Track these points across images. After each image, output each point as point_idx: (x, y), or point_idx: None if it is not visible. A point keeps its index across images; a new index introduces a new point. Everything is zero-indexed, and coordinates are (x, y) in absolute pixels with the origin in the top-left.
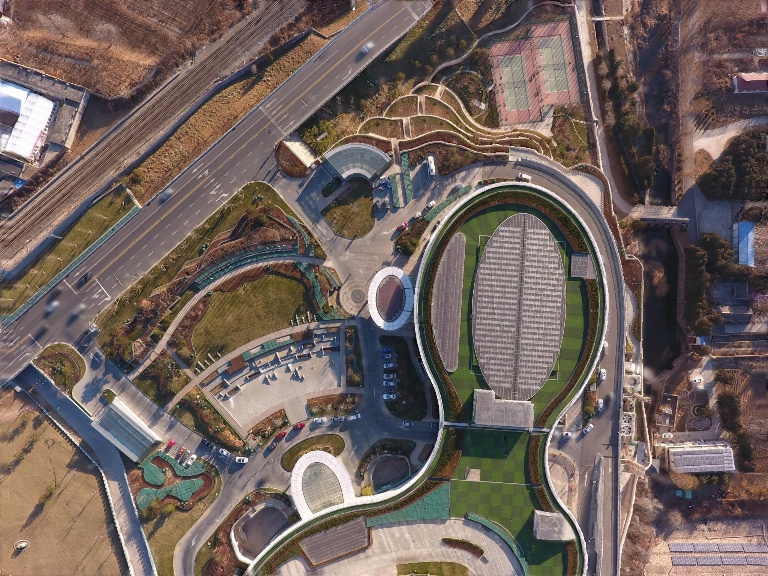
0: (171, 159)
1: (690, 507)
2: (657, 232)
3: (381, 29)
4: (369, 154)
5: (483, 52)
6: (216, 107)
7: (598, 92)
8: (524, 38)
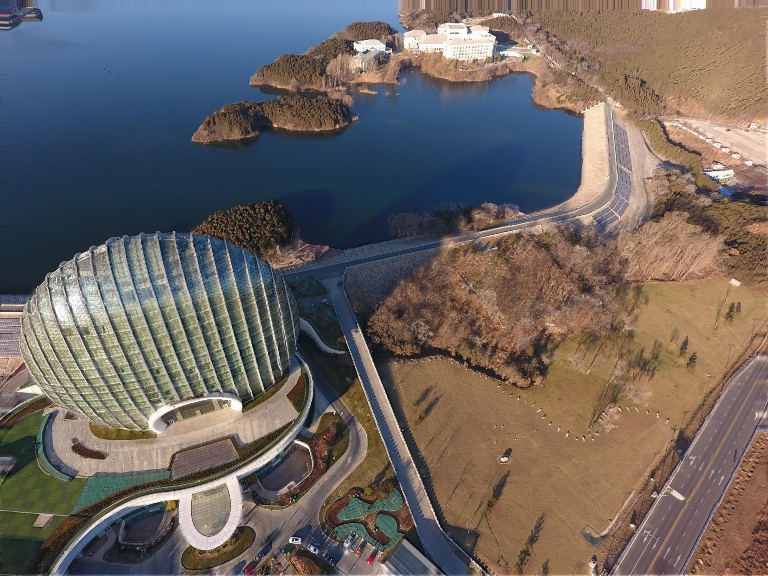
0: None
1: None
2: None
3: None
4: None
5: None
6: None
7: None
8: None
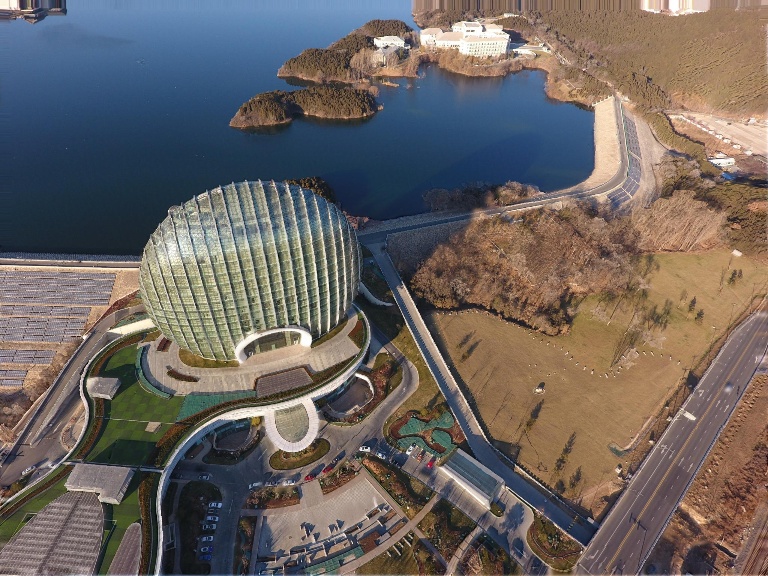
0: None
1: None
2: None
3: None
4: None
5: None
6: None
7: None
8: None
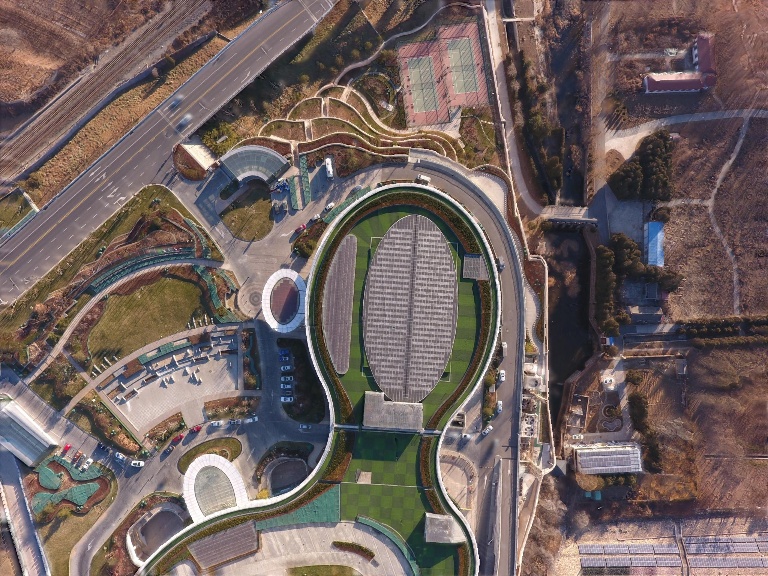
0: (70, 163)
1: (599, 509)
2: (572, 233)
3: (280, 32)
4: (265, 156)
5: (389, 54)
6: (116, 110)
7: (508, 93)
8: (432, 40)
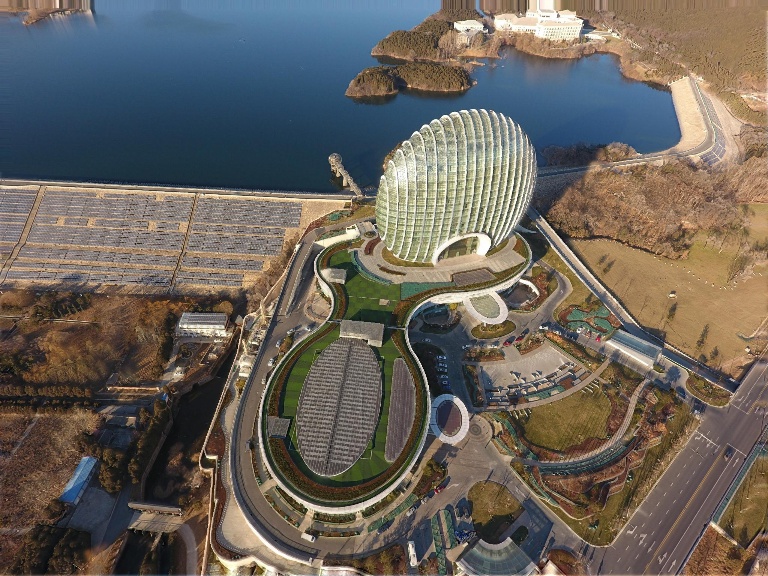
0: None
1: (220, 301)
2: None
3: None
4: (485, 568)
5: None
6: None
7: None
8: None
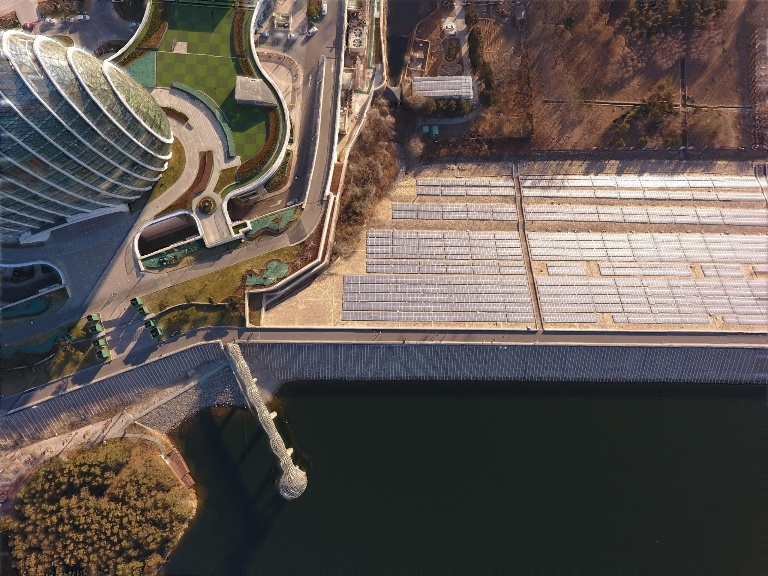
0: None
1: (436, 142)
2: None
3: None
4: None
5: None
6: None
7: None
8: None
